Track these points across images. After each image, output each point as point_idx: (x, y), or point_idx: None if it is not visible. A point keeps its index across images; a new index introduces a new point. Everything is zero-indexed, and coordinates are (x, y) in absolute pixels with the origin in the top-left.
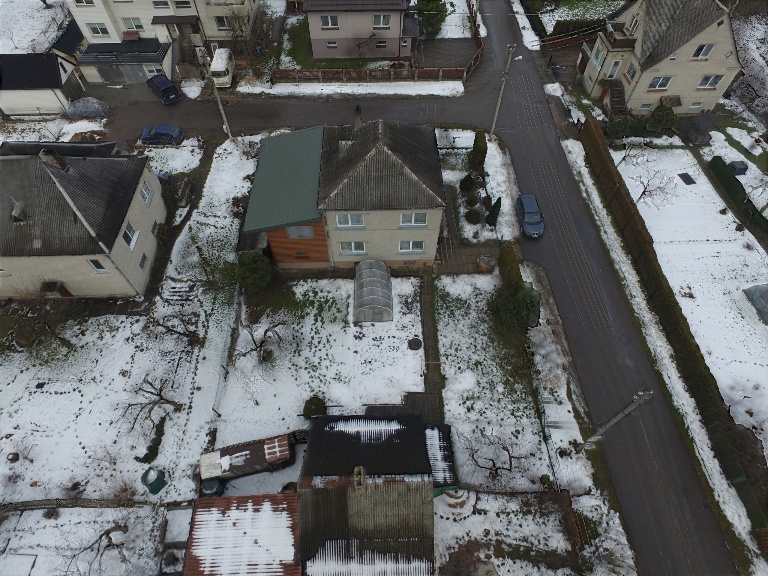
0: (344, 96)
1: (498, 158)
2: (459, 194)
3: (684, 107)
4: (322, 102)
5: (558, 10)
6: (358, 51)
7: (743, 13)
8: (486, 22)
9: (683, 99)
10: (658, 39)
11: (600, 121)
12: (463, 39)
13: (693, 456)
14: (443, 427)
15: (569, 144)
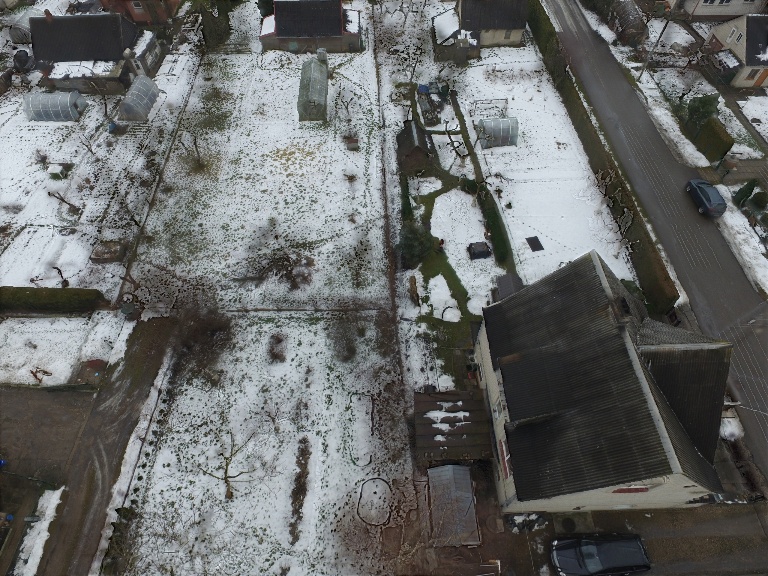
0: None
1: (762, 277)
2: None
3: None
4: None
5: None
6: None
7: None
8: None
9: None
10: None
11: None
12: None
13: (577, 77)
14: (727, 70)
15: None
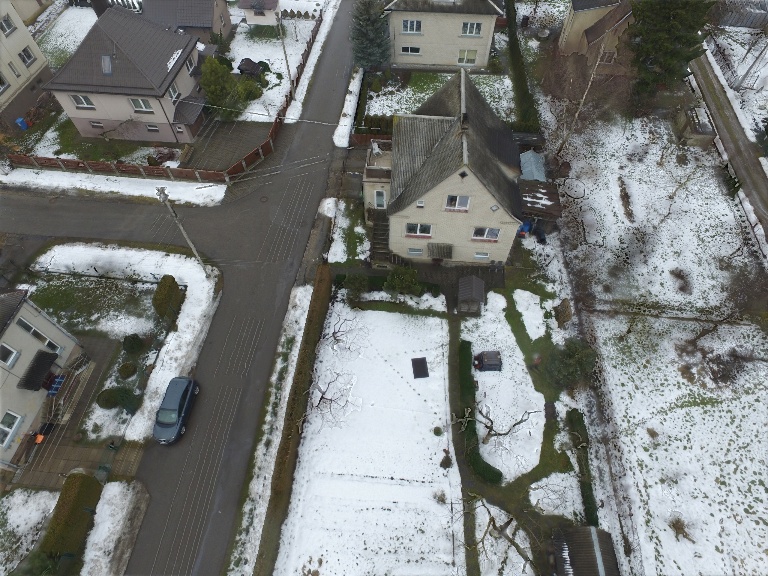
0: (80, 193)
1: (203, 305)
2: (121, 357)
3: (466, 256)
4: (50, 199)
5: (400, 92)
6: (129, 133)
7: (628, 114)
8: (307, 102)
9: (460, 248)
10: (412, 176)
11: (360, 261)
12: (266, 124)
13: None
14: None
15: (298, 294)
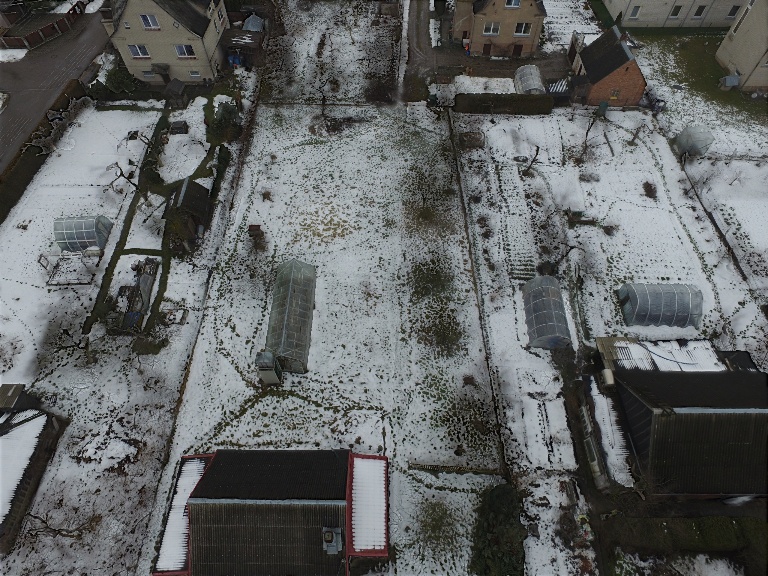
0: None
1: None
2: None
3: (184, 75)
4: None
5: None
6: None
7: None
8: (107, 0)
9: (175, 67)
10: None
11: None
12: (71, 14)
13: None
14: None
15: None
